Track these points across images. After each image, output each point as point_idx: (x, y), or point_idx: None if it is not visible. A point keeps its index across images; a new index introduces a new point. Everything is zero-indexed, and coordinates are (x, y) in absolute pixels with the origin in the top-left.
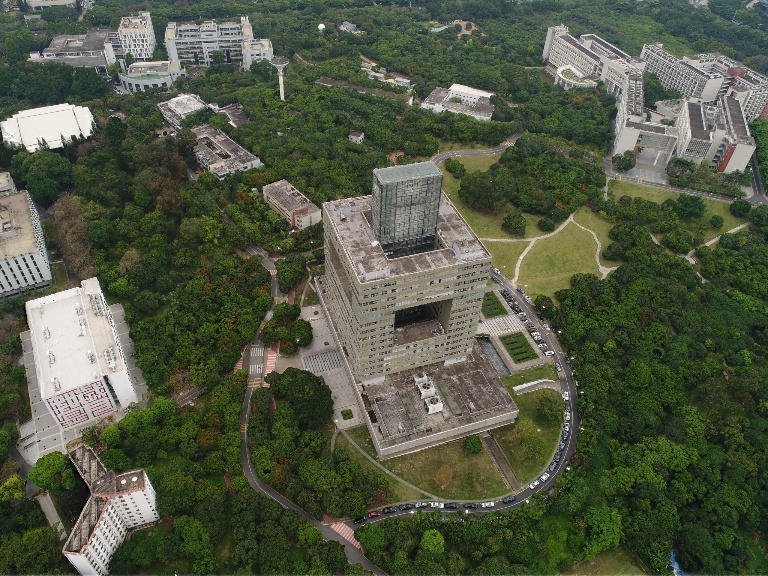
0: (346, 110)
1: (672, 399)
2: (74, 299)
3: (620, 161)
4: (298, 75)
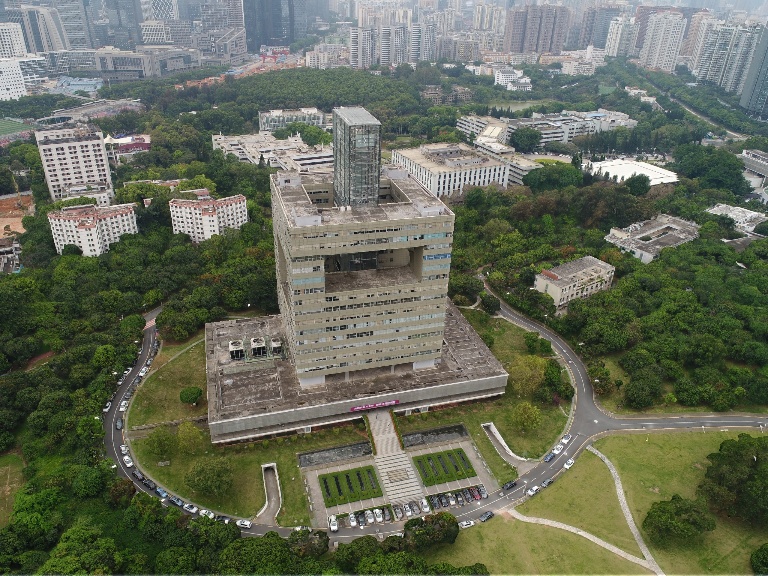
0: None
1: None
2: None
3: None
4: None
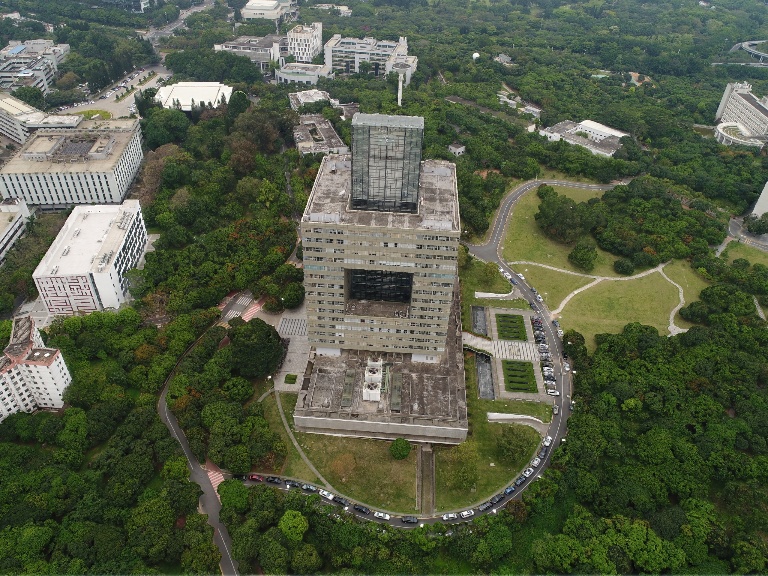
0: (459, 125)
1: (684, 486)
2: (115, 214)
3: (753, 222)
4: (431, 91)
